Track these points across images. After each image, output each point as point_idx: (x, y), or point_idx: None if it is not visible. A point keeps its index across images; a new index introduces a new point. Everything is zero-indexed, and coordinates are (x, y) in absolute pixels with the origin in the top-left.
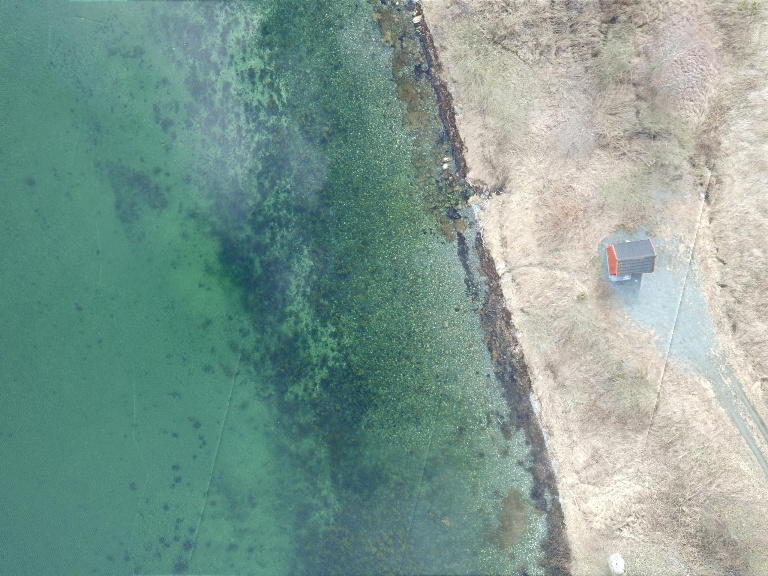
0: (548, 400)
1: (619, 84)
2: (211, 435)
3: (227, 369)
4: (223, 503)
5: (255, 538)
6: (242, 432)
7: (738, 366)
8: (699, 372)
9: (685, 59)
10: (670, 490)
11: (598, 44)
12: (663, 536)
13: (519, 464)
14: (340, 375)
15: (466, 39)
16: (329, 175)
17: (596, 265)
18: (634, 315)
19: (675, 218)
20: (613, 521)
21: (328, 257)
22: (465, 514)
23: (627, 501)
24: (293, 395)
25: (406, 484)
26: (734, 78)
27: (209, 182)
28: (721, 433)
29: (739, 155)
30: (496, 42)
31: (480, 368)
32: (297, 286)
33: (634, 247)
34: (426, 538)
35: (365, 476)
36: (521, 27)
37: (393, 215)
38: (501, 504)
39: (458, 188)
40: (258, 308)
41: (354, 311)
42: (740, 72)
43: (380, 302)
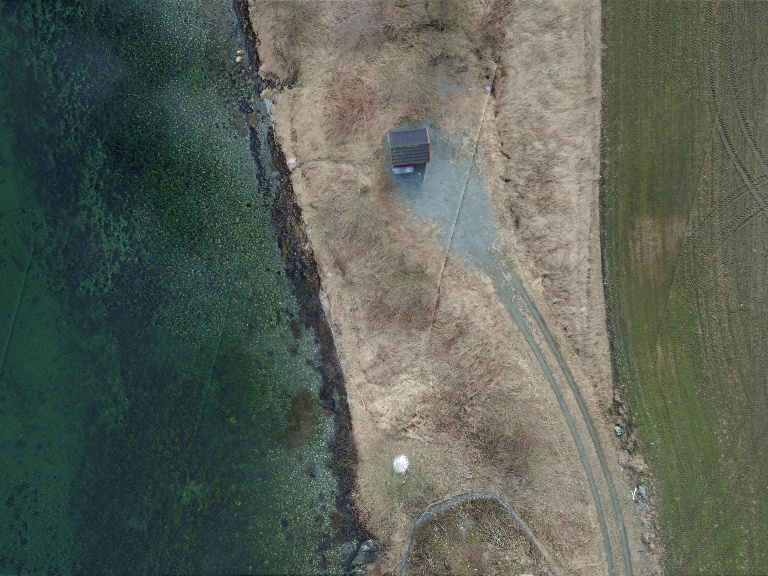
0: (337, 298)
1: None
2: (1, 329)
3: (19, 262)
4: (12, 398)
5: (44, 434)
6: (33, 327)
7: (519, 261)
8: (479, 267)
9: None
10: (453, 389)
11: None
12: (447, 437)
13: (308, 363)
14: (131, 270)
15: None
16: (124, 68)
17: (380, 158)
18: (416, 208)
19: (459, 111)
20: (398, 421)
21: (120, 150)
22: (253, 413)
23: (412, 401)
24: (85, 290)
25: (195, 382)
26: None
27: (5, 73)
28: (500, 329)
29: (522, 46)
30: None
31: (271, 265)
32: (90, 180)
33: (409, 135)
34: (214, 437)
35: (154, 373)
36: None
37: (186, 109)
38: (289, 403)
39: (251, 82)
40: (50, 201)
41: (147, 206)
42: None
43: (172, 197)
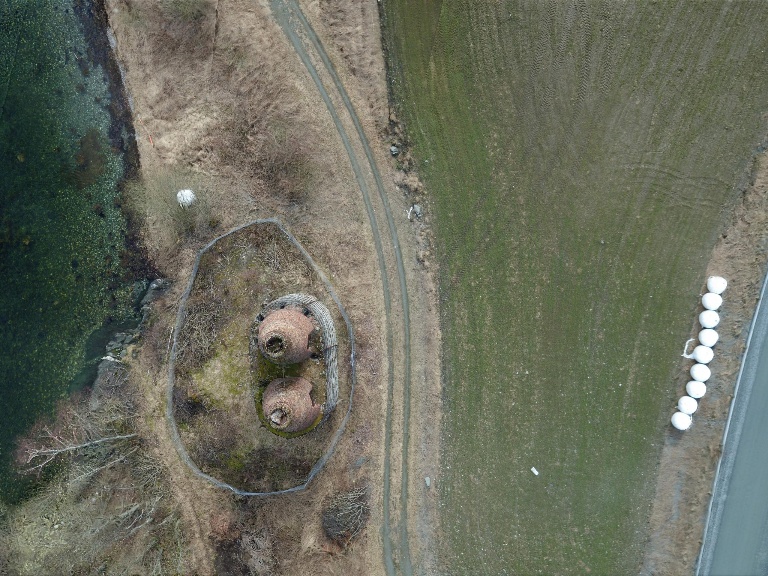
0: (123, 33)
1: None
2: None
3: None
4: None
5: None
6: None
7: None
8: None
9: None
10: (235, 118)
11: None
12: (232, 169)
13: (96, 102)
14: None
15: None
16: None
17: None
18: None
19: None
20: (184, 155)
21: None
22: (43, 154)
23: (198, 134)
24: None
25: None
26: None
27: None
28: (277, 51)
29: None
30: None
31: (59, 3)
32: None
33: None
34: (5, 179)
35: None
36: None
37: None
38: (78, 143)
39: None
40: None
41: None
42: None
43: None
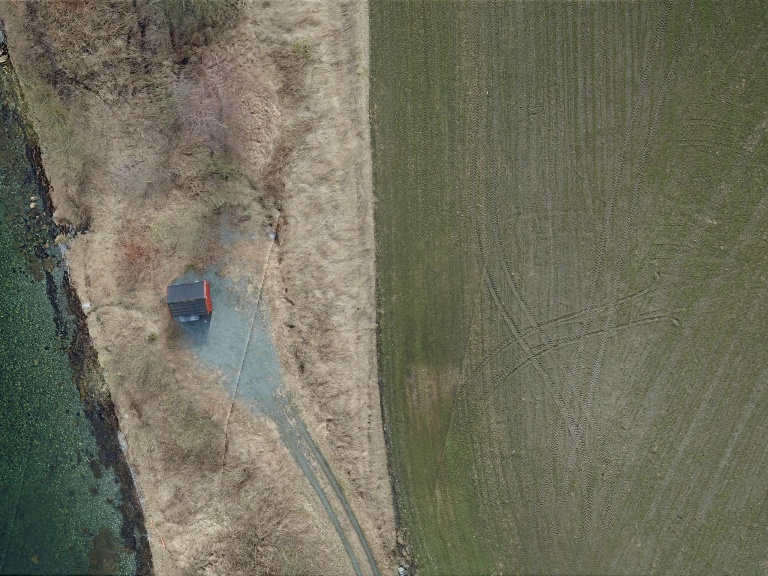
0: (134, 439)
1: (193, 124)
2: None
3: None
4: None
5: None
6: None
7: (304, 407)
8: (265, 413)
9: (251, 100)
10: (246, 530)
11: (171, 85)
12: (243, 575)
13: (109, 502)
14: None
15: (50, 79)
16: None
17: None
18: (203, 356)
19: (243, 259)
20: (195, 560)
21: None
22: (57, 552)
23: (209, 540)
24: None
25: None
26: (294, 120)
27: None
28: (285, 474)
29: (301, 196)
30: (78, 82)
31: (70, 406)
32: None
33: (187, 289)
34: (19, 575)
35: None
36: (100, 67)
37: None
38: (91, 542)
39: (45, 227)
40: None
41: None
42: (299, 114)
43: None
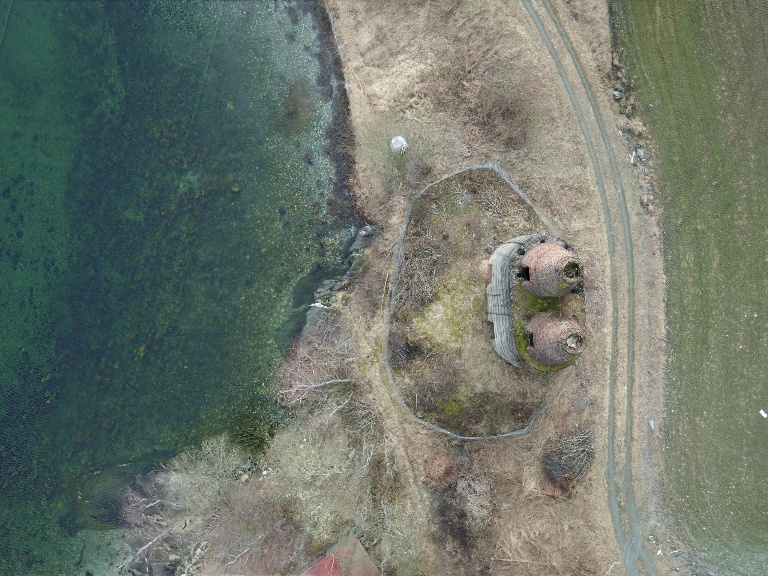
0: None
1: None
2: None
3: None
4: (8, 89)
5: (40, 126)
6: (29, 18)
7: None
8: None
9: None
10: (451, 65)
11: None
12: (445, 116)
13: (305, 49)
14: None
15: None
16: None
17: None
18: None
19: None
20: (396, 102)
21: None
22: (251, 101)
23: (410, 81)
24: None
25: (192, 71)
26: None
27: None
28: None
29: None
30: None
31: None
32: None
33: None
34: (212, 127)
35: (151, 62)
36: None
37: None
38: (287, 90)
39: None
40: None
41: None
42: None
43: None
